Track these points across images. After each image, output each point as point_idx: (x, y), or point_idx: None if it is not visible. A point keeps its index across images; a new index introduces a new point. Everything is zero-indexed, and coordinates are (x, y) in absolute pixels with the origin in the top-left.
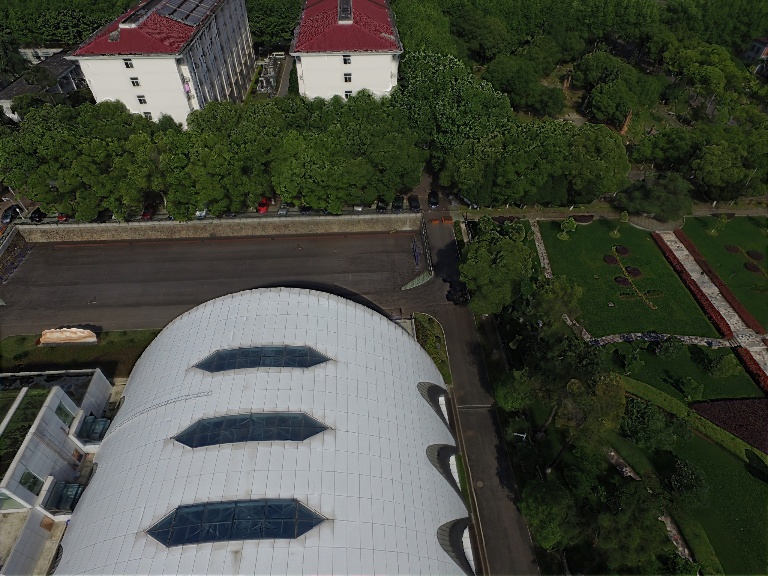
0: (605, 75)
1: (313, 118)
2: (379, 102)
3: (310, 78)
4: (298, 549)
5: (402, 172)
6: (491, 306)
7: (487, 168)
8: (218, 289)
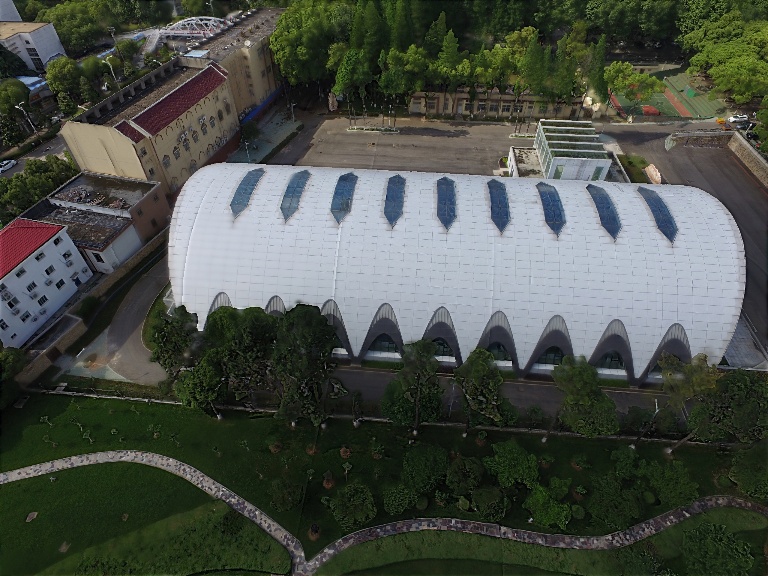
0: None
1: None
2: None
3: None
4: (541, 224)
5: None
6: None
7: None
8: None
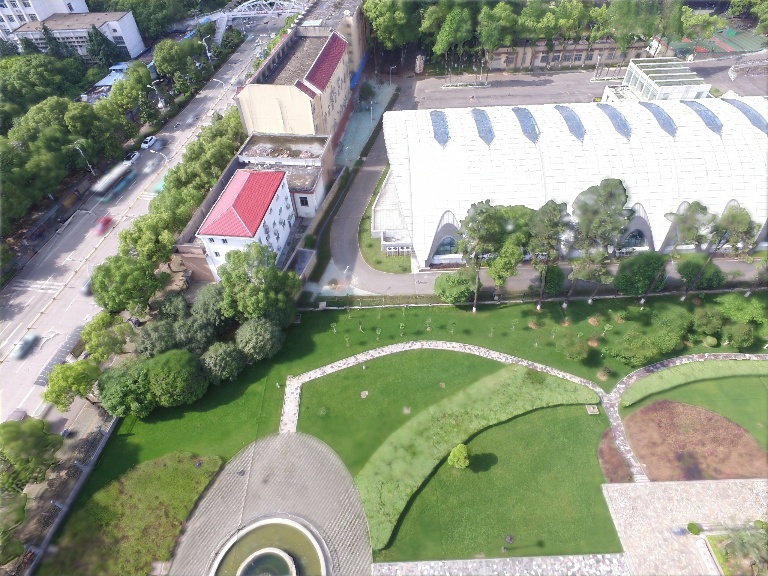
0: None
1: None
2: None
3: None
4: (703, 128)
5: None
6: None
7: None
8: None
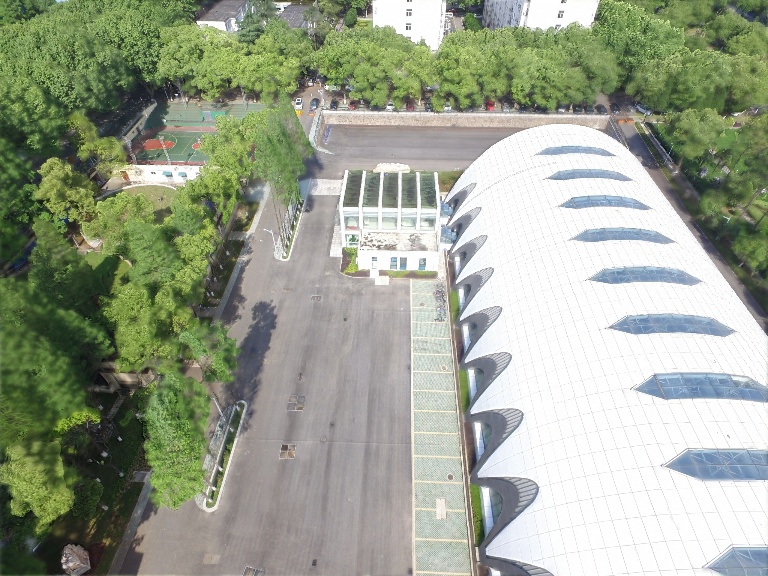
0: (736, 32)
1: (540, 40)
2: (588, 31)
3: (533, 14)
4: (646, 214)
5: (605, 80)
6: (697, 151)
7: (669, 79)
8: (474, 154)
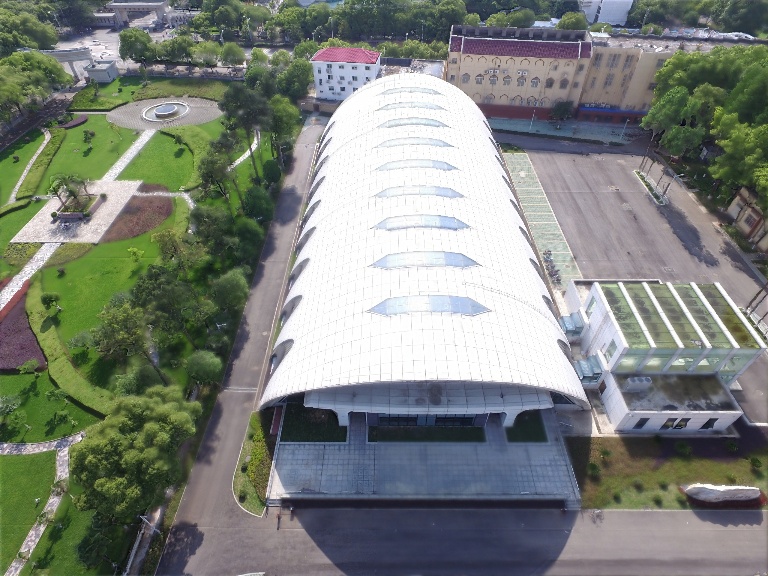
0: None
1: None
2: None
3: None
4: None
5: None
6: None
7: None
8: None
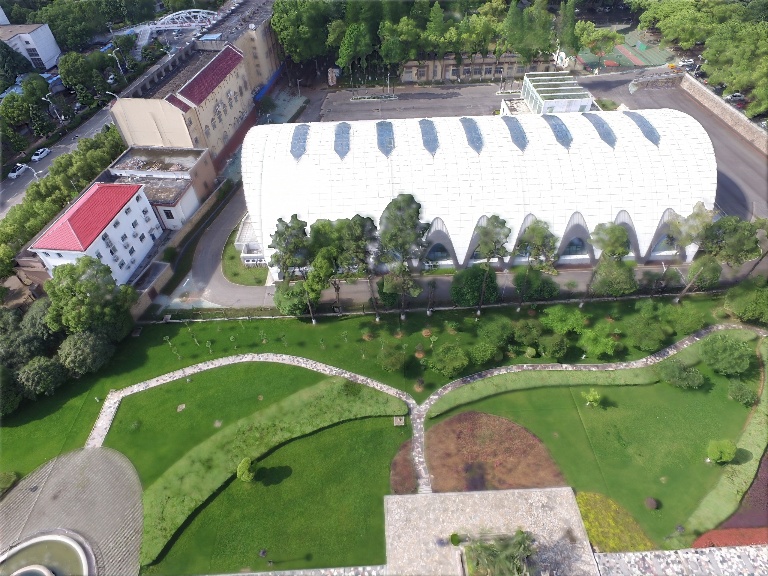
0: None
1: None
2: None
3: None
4: (553, 142)
5: None
6: None
7: None
8: None
